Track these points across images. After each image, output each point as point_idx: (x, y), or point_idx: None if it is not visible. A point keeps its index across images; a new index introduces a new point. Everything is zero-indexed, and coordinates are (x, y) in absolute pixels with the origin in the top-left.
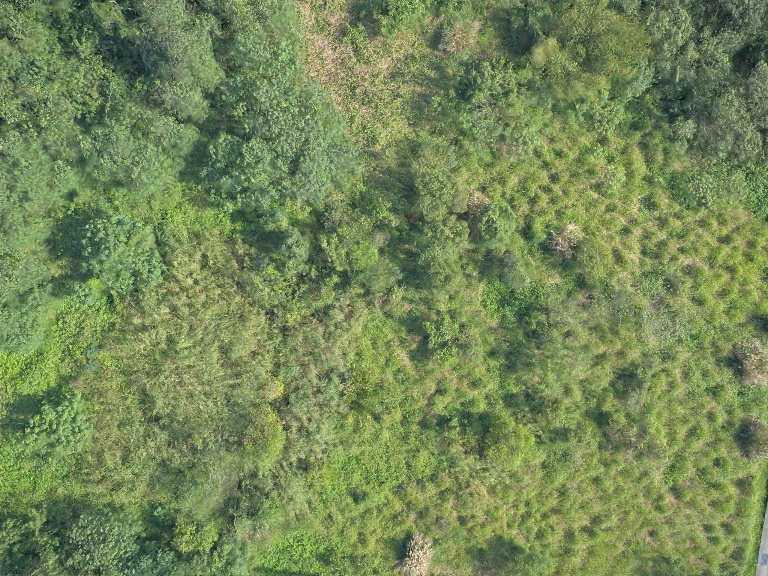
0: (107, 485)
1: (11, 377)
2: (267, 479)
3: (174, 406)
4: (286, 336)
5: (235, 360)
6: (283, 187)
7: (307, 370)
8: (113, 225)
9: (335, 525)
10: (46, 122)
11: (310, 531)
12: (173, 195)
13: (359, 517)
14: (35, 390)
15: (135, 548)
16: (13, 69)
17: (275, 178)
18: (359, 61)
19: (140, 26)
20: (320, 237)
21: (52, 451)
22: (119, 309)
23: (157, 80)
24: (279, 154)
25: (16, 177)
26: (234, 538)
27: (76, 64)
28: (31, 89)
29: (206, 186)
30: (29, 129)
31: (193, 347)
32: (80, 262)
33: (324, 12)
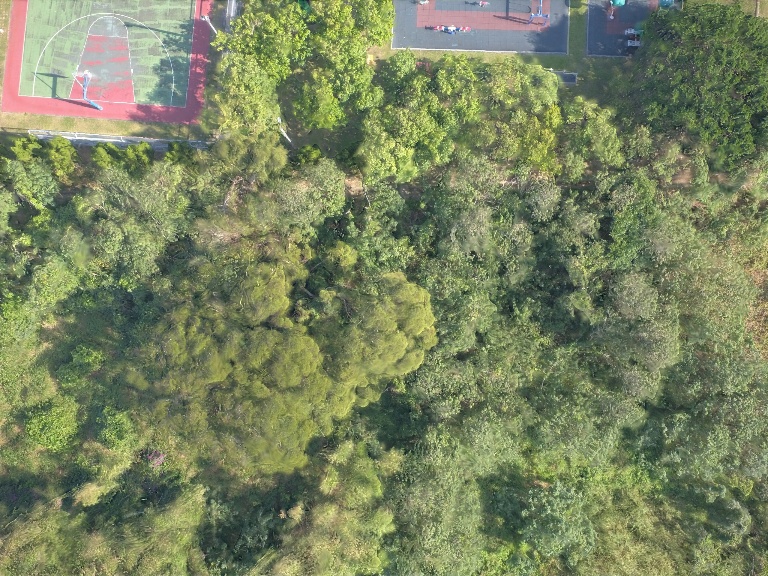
0: None
1: None
2: None
3: None
4: None
5: None
6: (733, 465)
7: None
8: (557, 499)
9: None
10: (507, 405)
11: None
12: None
13: None
14: None
15: None
16: None
17: (722, 454)
18: None
19: (608, 312)
20: (759, 509)
21: None
22: (541, 570)
23: (593, 346)
24: (738, 438)
25: (470, 456)
26: None
27: None
28: (495, 374)
29: (624, 443)
30: (488, 411)
31: None
32: (495, 517)
33: (749, 269)
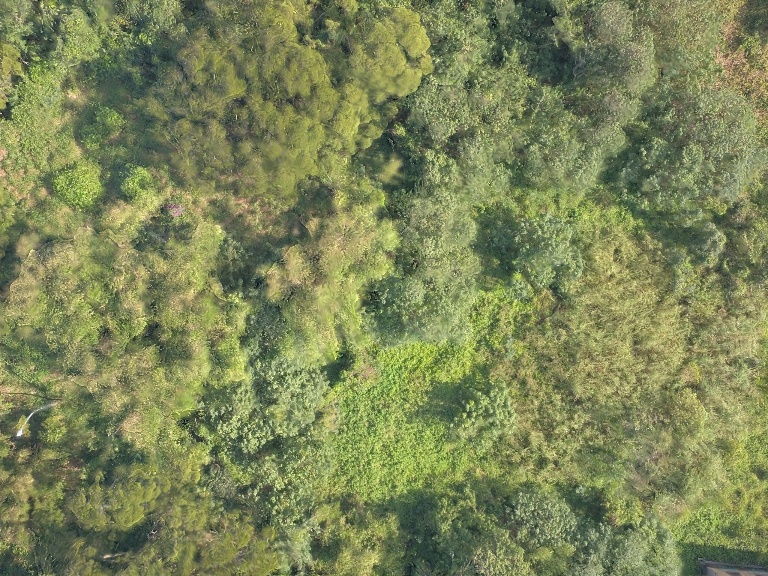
0: (526, 465)
1: (426, 366)
2: (686, 458)
3: (596, 391)
4: (696, 325)
5: (651, 347)
6: (707, 186)
7: (720, 356)
8: (547, 223)
9: (741, 500)
10: (499, 128)
11: (716, 506)
12: (578, 194)
13: (762, 493)
14: (452, 378)
15: (576, 522)
16: (461, 79)
17: (698, 177)
18: (752, 67)
19: (588, 38)
20: (734, 232)
21: (481, 434)
22: (535, 301)
23: (576, 87)
24: (711, 155)
25: (466, 179)
26: (652, 513)
27: (507, 73)
28: (487, 97)
29: (608, 186)
30: (482, 135)
31: (613, 336)
32: (491, 258)
33: None
